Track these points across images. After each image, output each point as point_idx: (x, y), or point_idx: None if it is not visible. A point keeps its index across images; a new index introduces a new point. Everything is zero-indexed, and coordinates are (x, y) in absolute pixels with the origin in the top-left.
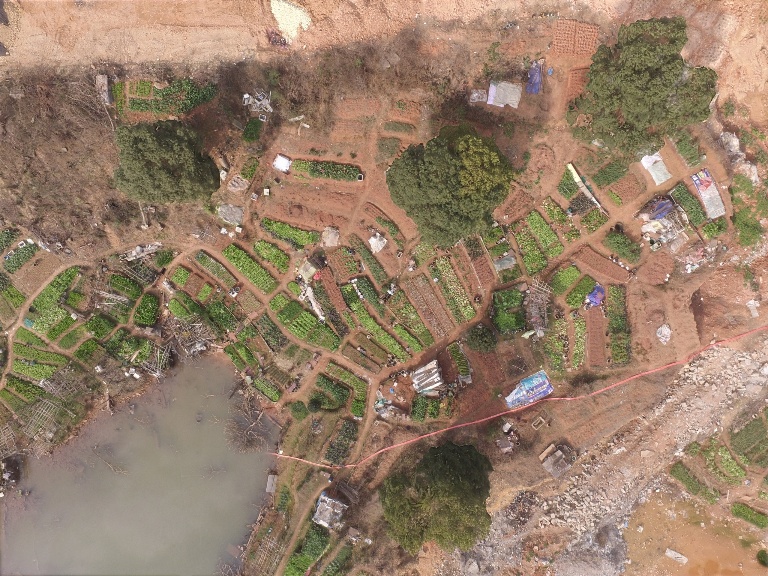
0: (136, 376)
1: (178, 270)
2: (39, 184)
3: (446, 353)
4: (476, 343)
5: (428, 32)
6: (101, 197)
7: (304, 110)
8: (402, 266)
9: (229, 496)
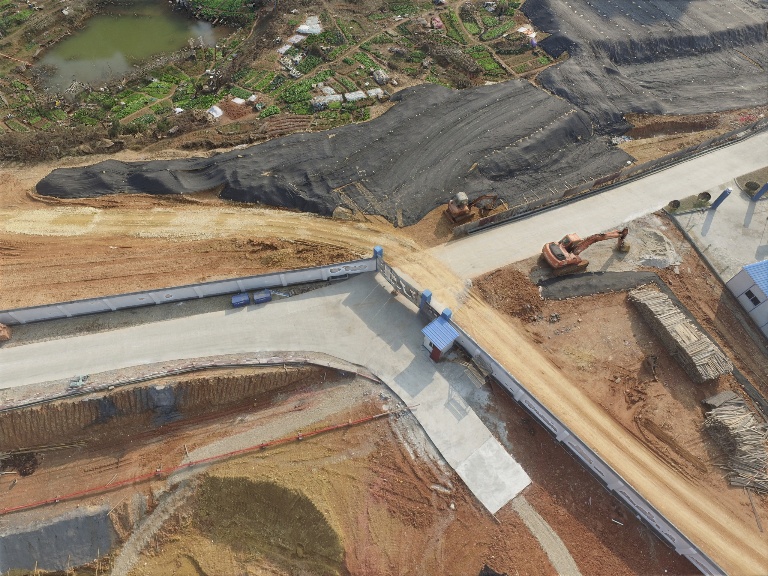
0: None
1: None
2: None
3: None
4: None
5: None
6: None
7: None
8: None
9: None
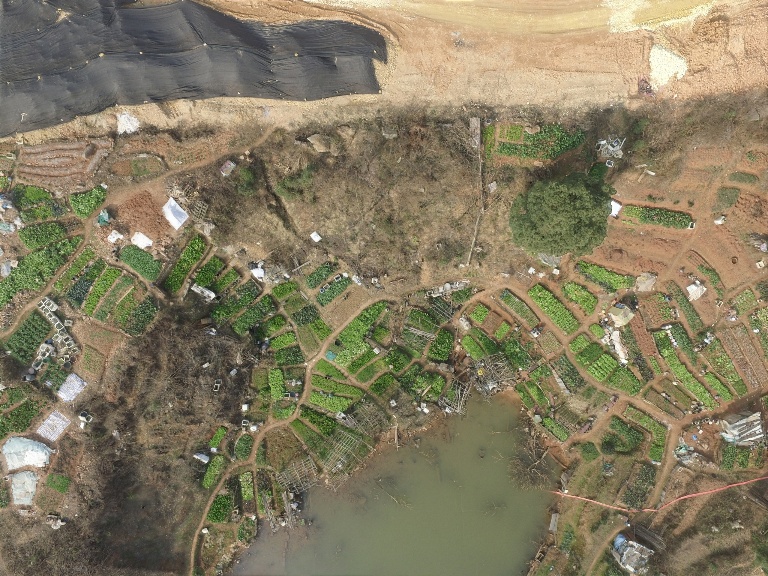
0: (426, 411)
1: (478, 307)
2: (380, 222)
3: (760, 404)
4: None
5: None
6: (436, 236)
7: (660, 159)
8: (719, 315)
9: (508, 532)
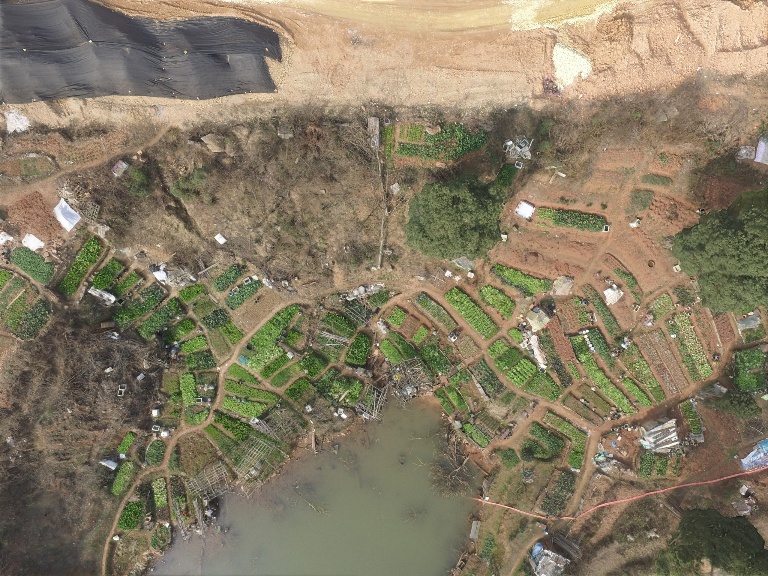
0: (343, 416)
1: (395, 311)
2: (284, 223)
3: (678, 410)
4: (739, 409)
5: (708, 86)
6: (343, 238)
7: (568, 160)
8: (636, 319)
9: (429, 540)
